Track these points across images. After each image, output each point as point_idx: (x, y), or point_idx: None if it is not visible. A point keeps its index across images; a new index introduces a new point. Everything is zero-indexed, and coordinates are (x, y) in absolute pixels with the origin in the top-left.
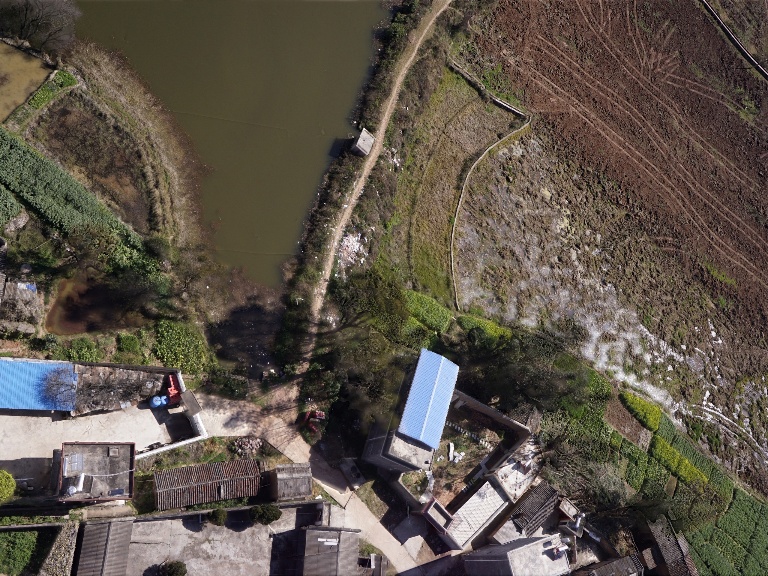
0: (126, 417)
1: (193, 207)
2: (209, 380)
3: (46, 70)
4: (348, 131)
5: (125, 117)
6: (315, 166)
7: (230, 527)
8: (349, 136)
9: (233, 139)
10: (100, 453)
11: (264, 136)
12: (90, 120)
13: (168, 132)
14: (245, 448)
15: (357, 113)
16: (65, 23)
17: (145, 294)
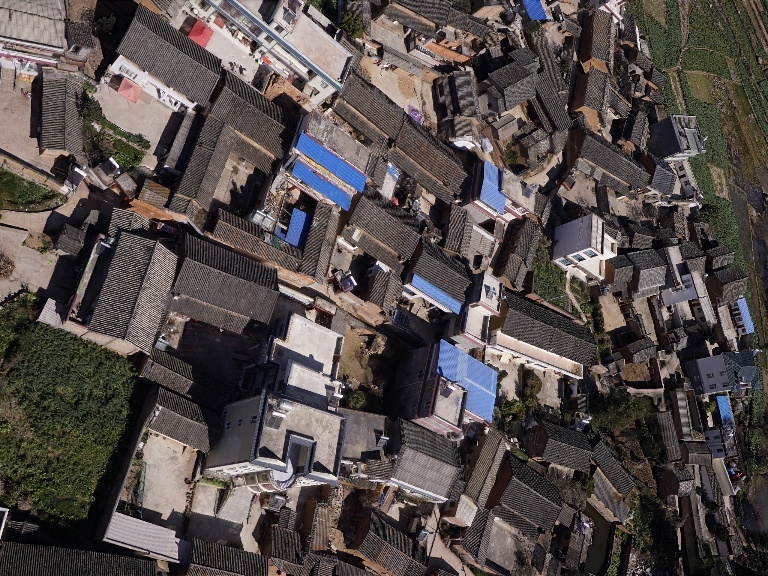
0: None
1: None
2: (737, 496)
3: None
4: None
5: None
6: None
7: (706, 518)
8: None
9: None
10: (733, 442)
11: None
12: None
13: None
14: None
15: None
16: None
17: None
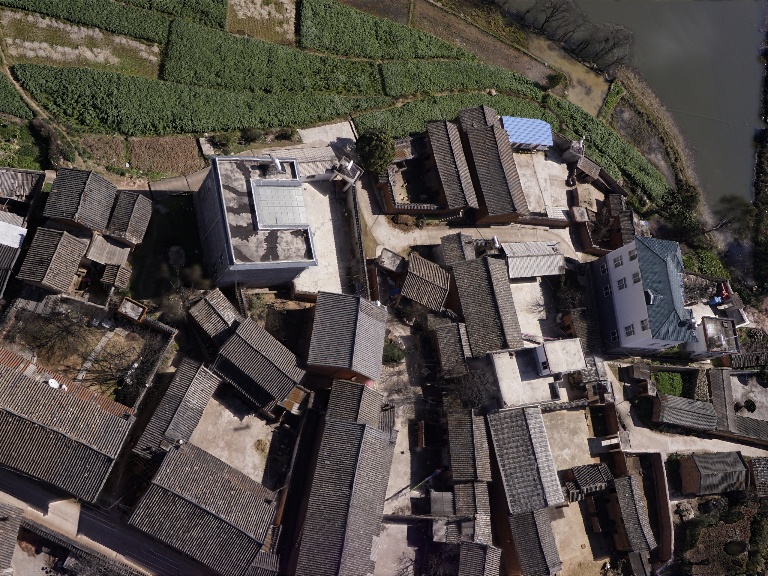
0: (699, 309)
1: (695, 176)
2: None
3: (607, 83)
4: (761, 124)
5: (650, 114)
6: (747, 148)
7: (761, 384)
8: (762, 127)
9: (704, 129)
10: (719, 324)
11: (719, 127)
12: (634, 117)
13: (672, 124)
14: (758, 335)
15: (763, 111)
16: (626, 52)
17: (690, 232)
